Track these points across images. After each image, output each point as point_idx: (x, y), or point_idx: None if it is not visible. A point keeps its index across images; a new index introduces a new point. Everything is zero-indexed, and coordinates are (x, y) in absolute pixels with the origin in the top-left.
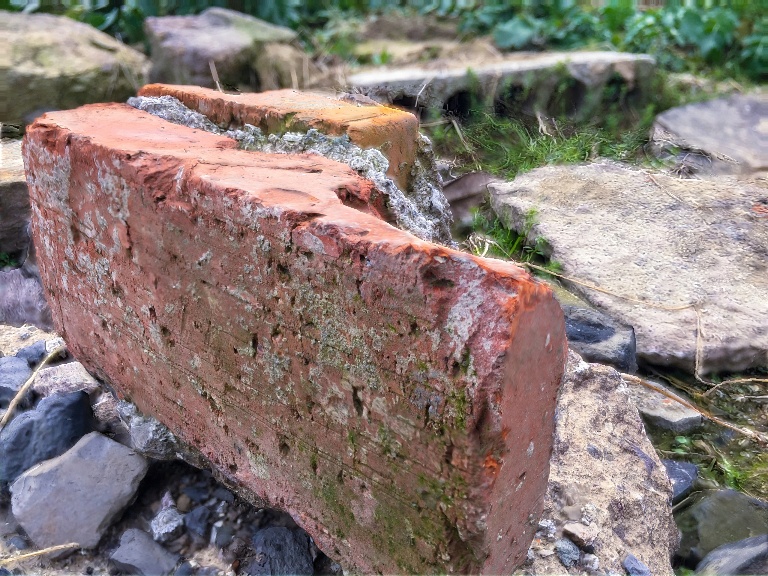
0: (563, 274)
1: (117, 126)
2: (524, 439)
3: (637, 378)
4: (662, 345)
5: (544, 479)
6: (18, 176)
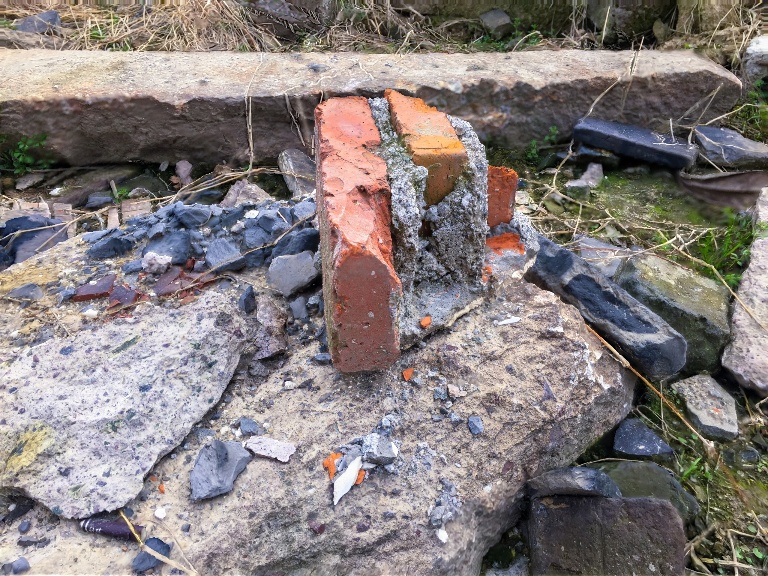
0: (739, 287)
1: (346, 117)
2: (364, 308)
3: (626, 363)
4: (751, 372)
5: (390, 335)
6: (406, 85)
